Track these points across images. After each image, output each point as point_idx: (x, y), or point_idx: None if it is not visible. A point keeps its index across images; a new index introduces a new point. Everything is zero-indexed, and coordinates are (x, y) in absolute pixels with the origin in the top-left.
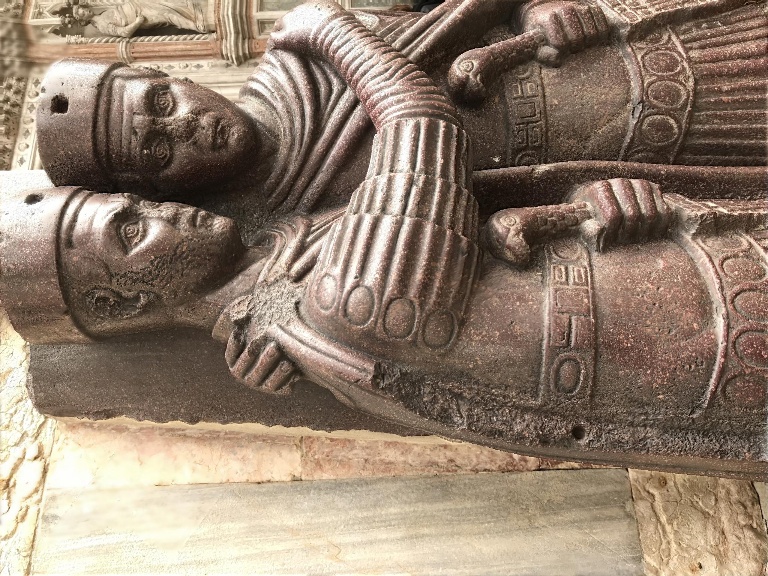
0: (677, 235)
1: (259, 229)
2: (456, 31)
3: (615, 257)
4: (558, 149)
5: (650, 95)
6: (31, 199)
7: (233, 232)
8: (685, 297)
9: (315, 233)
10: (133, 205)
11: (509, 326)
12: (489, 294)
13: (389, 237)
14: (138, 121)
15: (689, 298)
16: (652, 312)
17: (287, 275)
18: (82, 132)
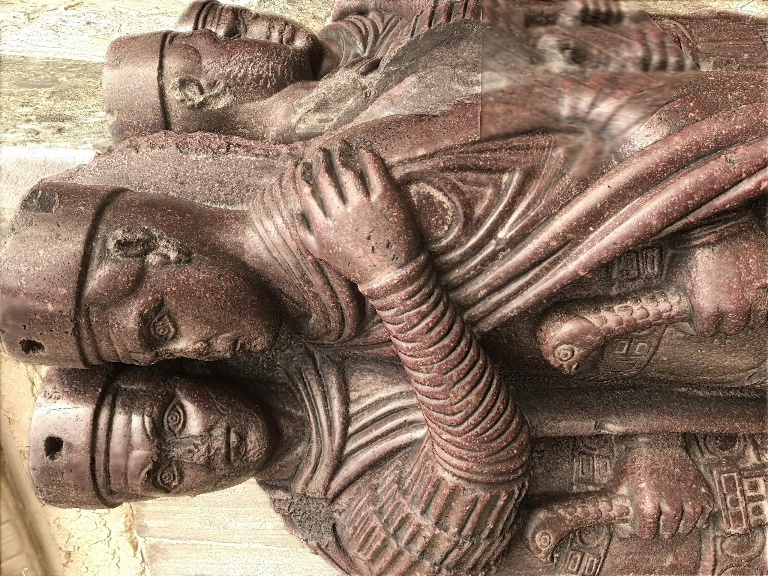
0: None
1: (288, 349)
2: None
3: (633, 545)
4: (644, 376)
5: None
6: (49, 442)
7: (268, 452)
8: None
9: (352, 446)
10: (161, 450)
11: None
12: (505, 574)
13: None
14: (138, 358)
15: None
16: None
17: (325, 499)
18: (72, 365)
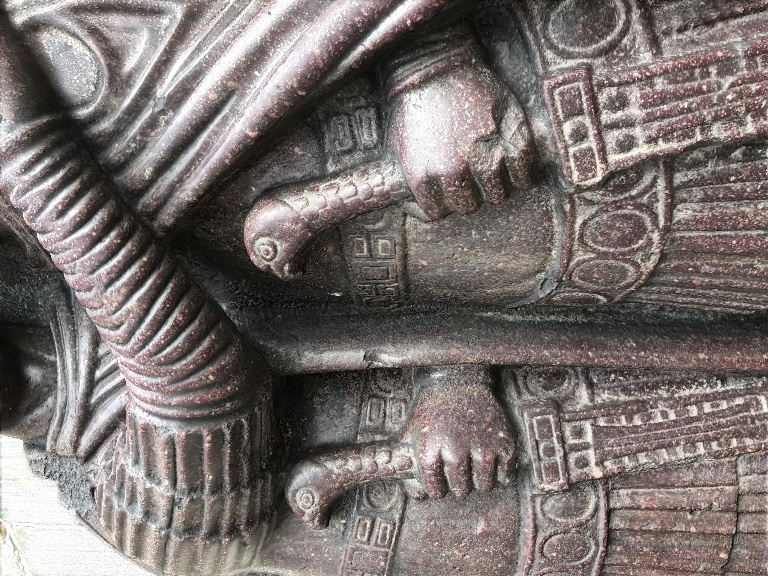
0: (521, 479)
1: (45, 284)
2: (252, 150)
3: (434, 508)
4: (425, 294)
5: (575, 275)
6: None
7: None
8: (489, 568)
9: (99, 393)
10: None
11: (302, 569)
12: (283, 544)
13: (155, 548)
14: None
15: (493, 569)
16: (450, 573)
17: (75, 457)
18: None
